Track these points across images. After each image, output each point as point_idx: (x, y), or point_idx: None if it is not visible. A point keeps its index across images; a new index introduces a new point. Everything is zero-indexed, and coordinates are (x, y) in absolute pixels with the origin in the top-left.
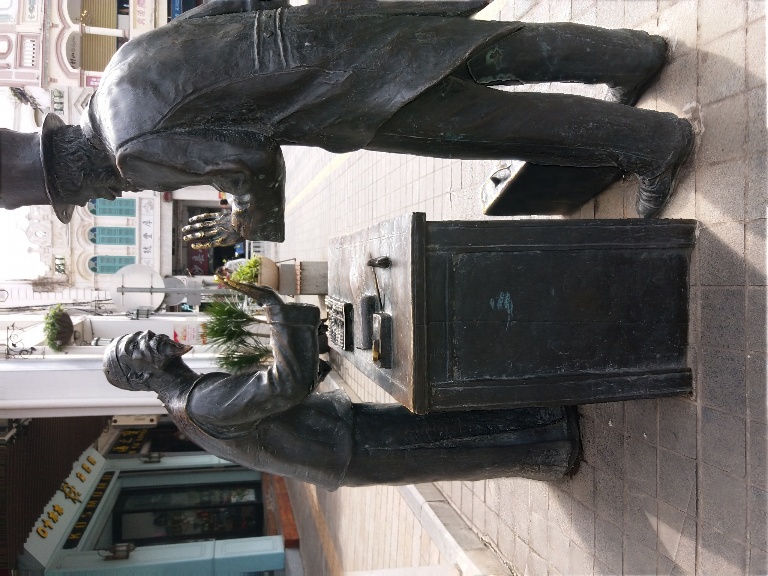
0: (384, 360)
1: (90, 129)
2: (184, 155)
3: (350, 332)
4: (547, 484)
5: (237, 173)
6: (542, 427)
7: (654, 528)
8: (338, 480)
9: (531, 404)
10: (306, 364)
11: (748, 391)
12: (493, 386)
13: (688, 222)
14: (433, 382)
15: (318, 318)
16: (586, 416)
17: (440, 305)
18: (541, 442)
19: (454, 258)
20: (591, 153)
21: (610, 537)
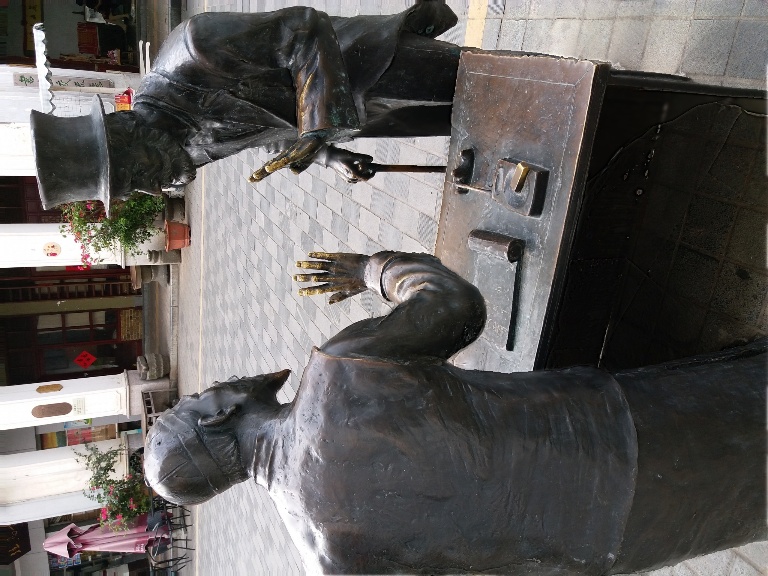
0: None
1: (144, 85)
2: None
3: None
4: None
5: None
6: None
7: None
8: (624, 415)
9: None
10: None
11: None
12: None
13: None
14: None
15: None
16: None
17: None
18: None
19: None
20: None
21: None
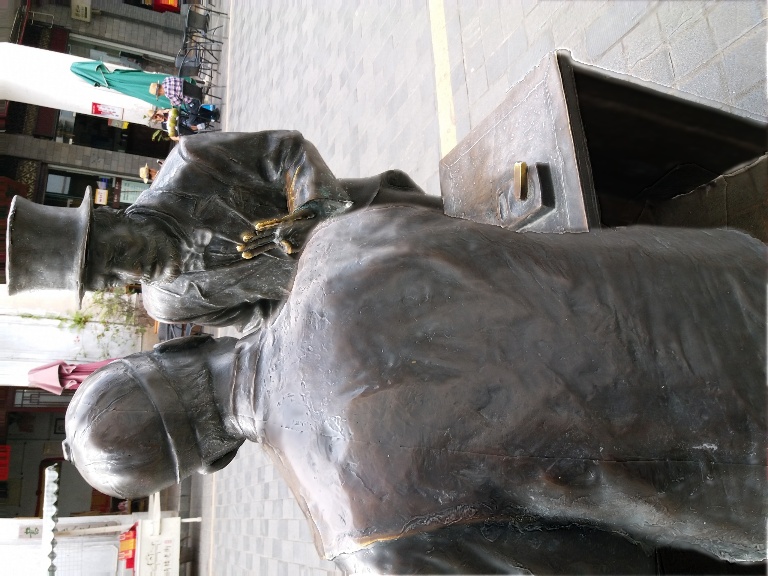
0: None
1: None
2: None
3: None
4: None
5: None
6: None
7: None
8: None
9: None
10: None
11: (762, 76)
12: None
13: None
14: None
15: None
16: None
17: None
18: None
19: None
20: None
21: None
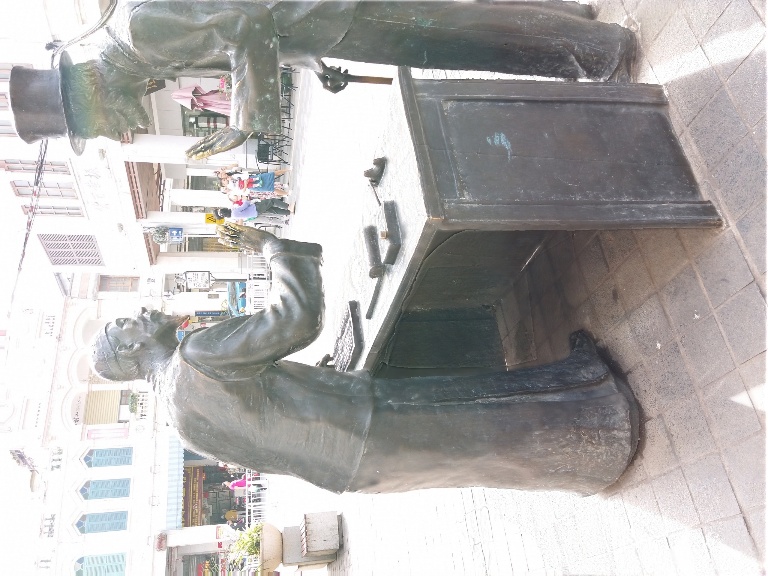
0: (392, 238)
1: (106, 42)
2: (189, 10)
3: (358, 329)
4: (619, 496)
5: (235, 18)
6: (588, 389)
7: (748, 405)
8: (361, 442)
9: (553, 222)
10: (312, 293)
11: None
12: (508, 205)
13: (654, 85)
14: (444, 199)
15: (321, 253)
16: (633, 367)
17: (437, 137)
18: (591, 399)
19: (443, 105)
20: (548, 43)
21: (708, 476)
